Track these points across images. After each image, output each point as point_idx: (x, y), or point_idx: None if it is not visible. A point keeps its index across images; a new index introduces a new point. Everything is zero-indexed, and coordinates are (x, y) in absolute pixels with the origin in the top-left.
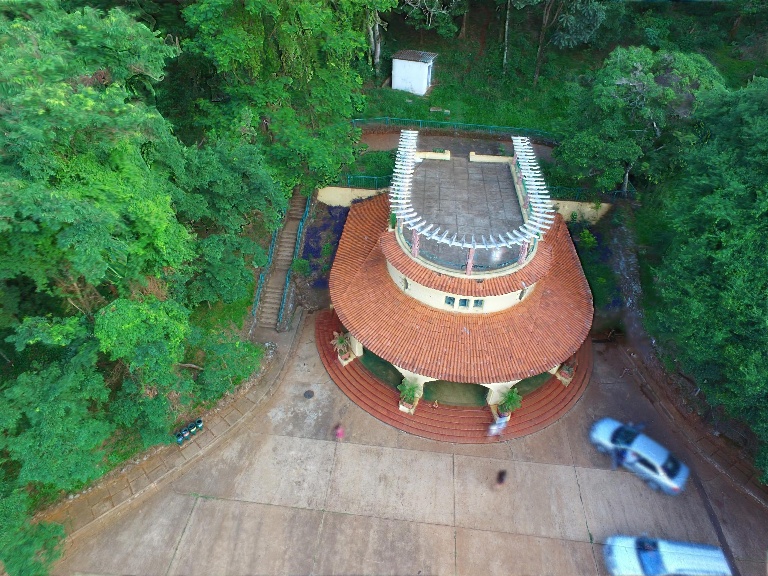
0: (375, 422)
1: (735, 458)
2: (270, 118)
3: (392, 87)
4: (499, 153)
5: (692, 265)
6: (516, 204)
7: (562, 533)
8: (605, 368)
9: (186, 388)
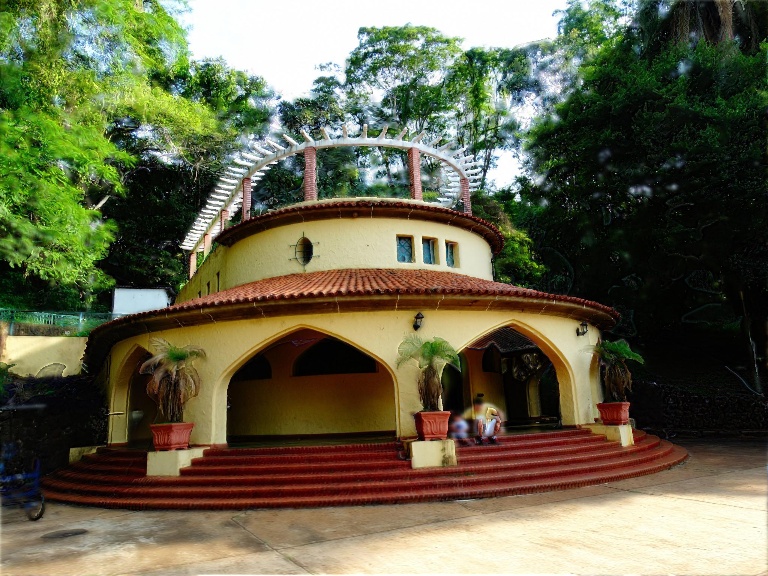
0: (366, 508)
1: None
2: None
3: None
4: None
5: None
6: None
7: None
8: None
9: None
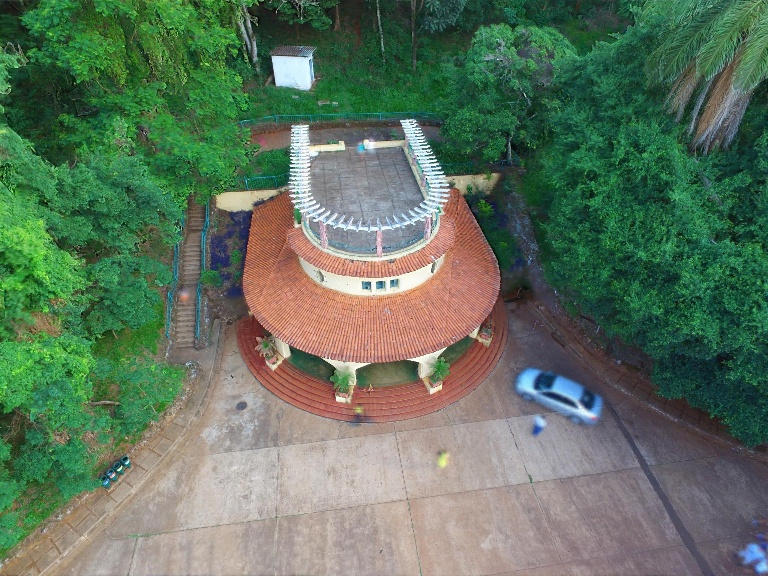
0: (314, 419)
1: (636, 380)
2: (148, 127)
3: (276, 85)
4: (392, 138)
5: (573, 215)
6: (415, 184)
7: (505, 481)
8: (519, 324)
9: (102, 425)
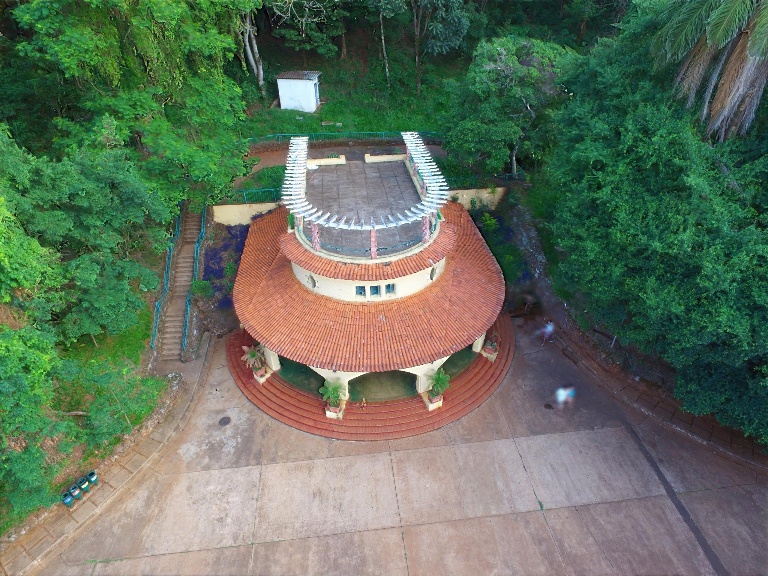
0: (302, 436)
1: (657, 398)
2: (142, 131)
3: (281, 107)
4: None
5: (580, 211)
6: (415, 193)
7: (512, 507)
8: (527, 339)
9: (61, 430)
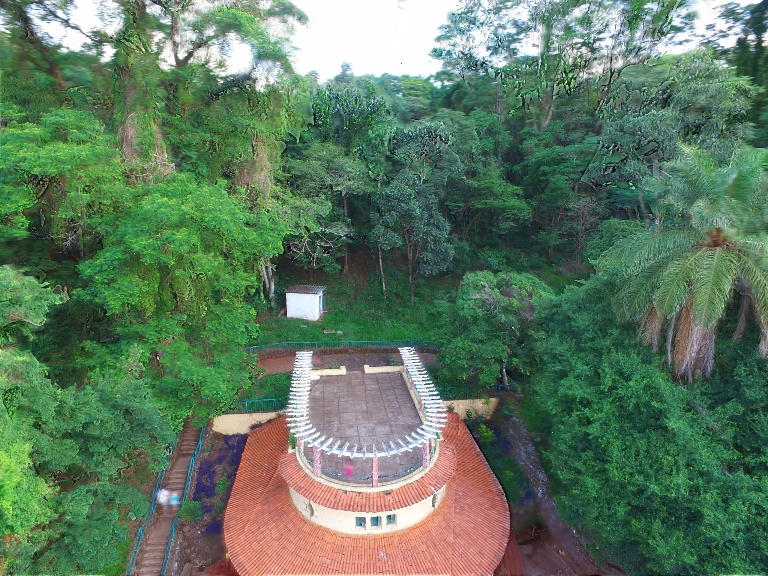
0: None
1: None
2: (162, 352)
3: (287, 316)
4: (392, 364)
5: (574, 443)
6: (413, 408)
7: None
8: (539, 574)
9: None
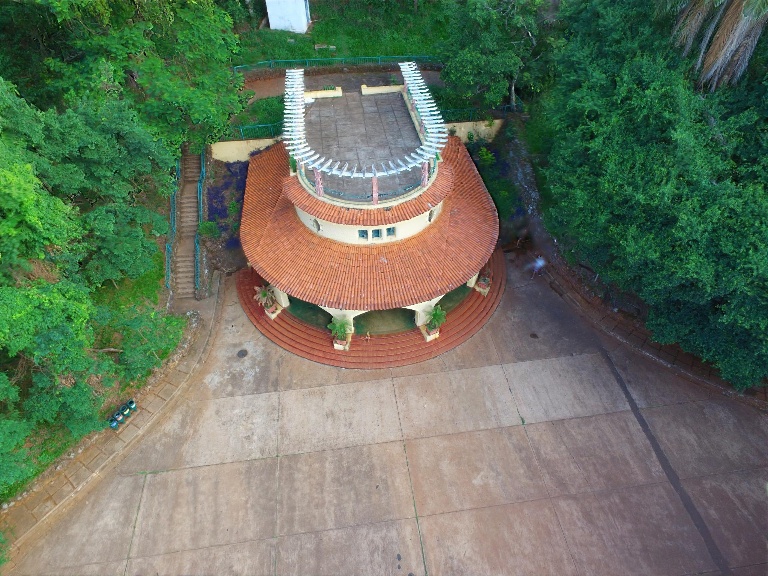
0: (313, 365)
1: (632, 327)
2: (136, 71)
3: (270, 28)
4: (391, 84)
5: (572, 158)
6: (413, 131)
7: (498, 423)
8: (517, 273)
9: (105, 369)
